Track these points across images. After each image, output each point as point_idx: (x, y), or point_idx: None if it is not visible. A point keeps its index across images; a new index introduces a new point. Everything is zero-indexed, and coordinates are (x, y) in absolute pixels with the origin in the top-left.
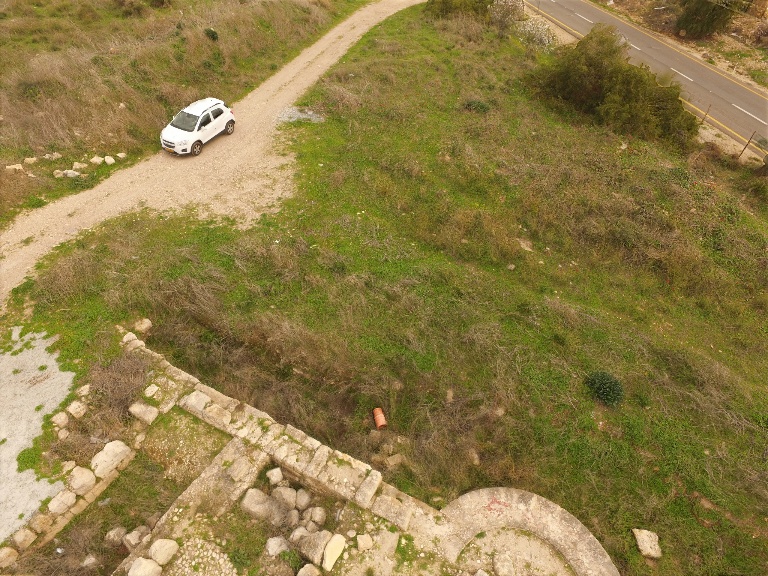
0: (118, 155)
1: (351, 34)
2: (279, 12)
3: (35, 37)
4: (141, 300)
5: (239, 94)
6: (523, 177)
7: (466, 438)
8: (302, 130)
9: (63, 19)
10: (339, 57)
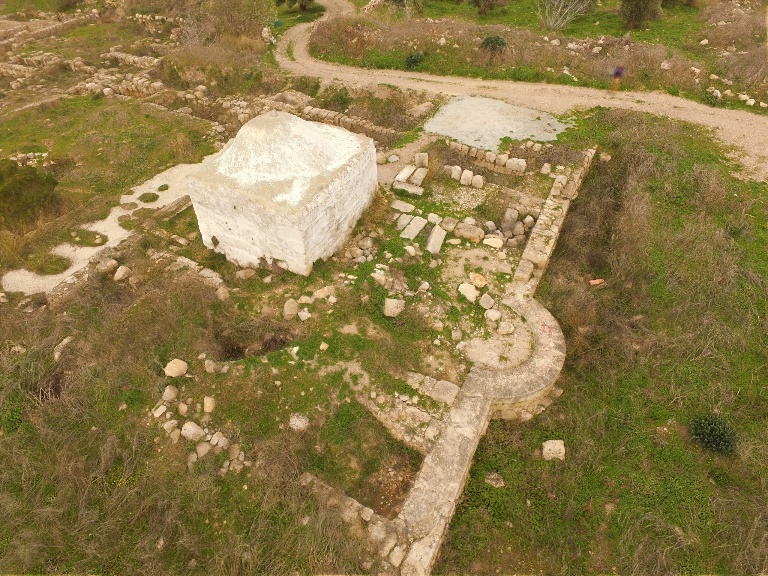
0: (761, 103)
1: None
2: None
3: None
4: (621, 145)
5: None
6: None
7: (600, 327)
8: None
9: None
10: None
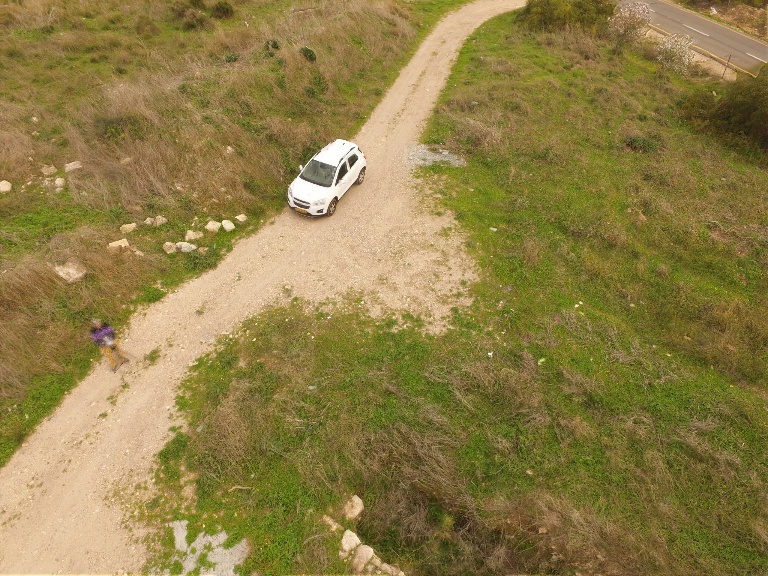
0: (238, 218)
1: (445, 50)
2: (367, 25)
3: (94, 56)
4: (349, 470)
5: (352, 128)
6: (755, 246)
7: None
8: (446, 177)
9: (118, 32)
10: (445, 78)
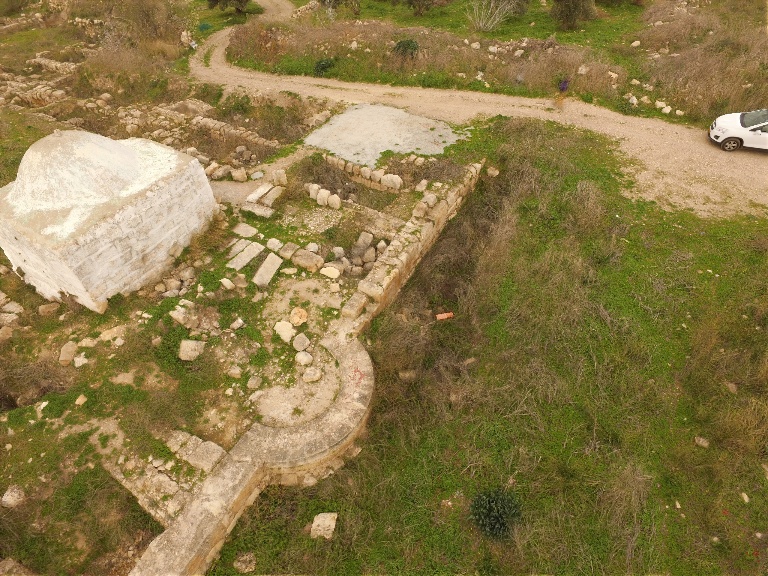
0: (677, 111)
1: None
2: None
3: None
4: (508, 159)
5: None
6: None
7: (426, 372)
8: None
9: None
10: None
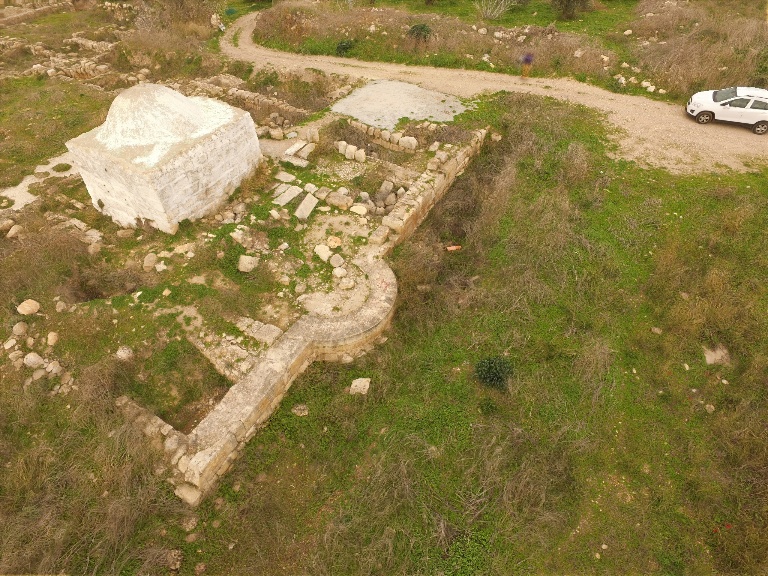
0: (660, 90)
1: None
2: None
3: None
4: (510, 126)
5: None
6: None
7: None
8: None
9: None
10: None
